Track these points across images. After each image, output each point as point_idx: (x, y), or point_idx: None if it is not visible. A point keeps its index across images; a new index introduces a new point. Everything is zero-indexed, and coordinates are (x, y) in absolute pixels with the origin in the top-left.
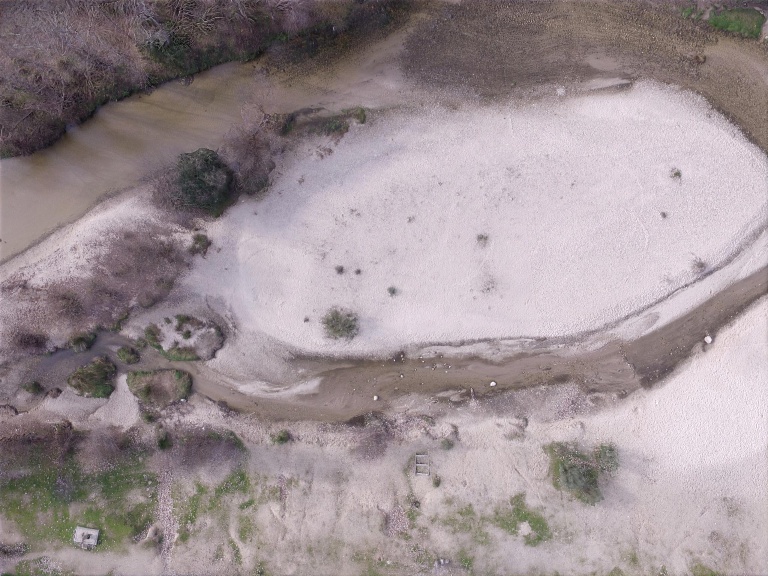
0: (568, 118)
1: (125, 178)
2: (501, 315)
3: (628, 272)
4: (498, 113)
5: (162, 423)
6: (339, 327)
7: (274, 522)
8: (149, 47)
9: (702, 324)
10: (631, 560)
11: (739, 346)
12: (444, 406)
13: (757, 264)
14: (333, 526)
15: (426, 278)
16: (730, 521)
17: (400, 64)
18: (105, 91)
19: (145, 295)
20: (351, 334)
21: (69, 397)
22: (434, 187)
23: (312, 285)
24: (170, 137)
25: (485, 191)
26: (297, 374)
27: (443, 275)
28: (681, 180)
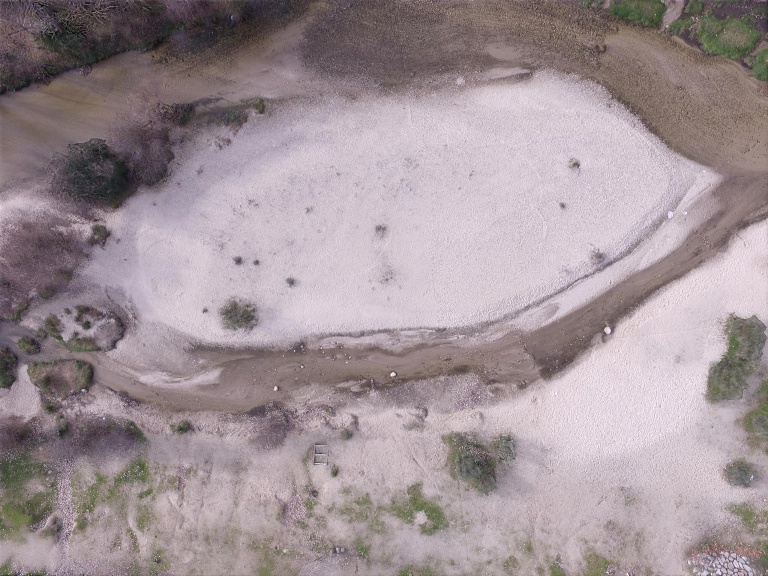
0: (467, 108)
1: (24, 169)
2: (400, 306)
3: (527, 263)
4: (397, 103)
5: (63, 413)
6: (238, 318)
7: (172, 511)
8: (42, 36)
9: (602, 315)
10: (526, 549)
11: (638, 337)
12: (344, 396)
13: (657, 255)
14: (231, 515)
15: (325, 269)
16: (627, 510)
17: (299, 54)
18: (1, 81)
19: (44, 286)
20: (250, 325)
21: None
22: (332, 177)
23: (210, 276)
24: (69, 127)
25: (383, 181)
26: (198, 365)
27: (342, 266)
28: (580, 170)
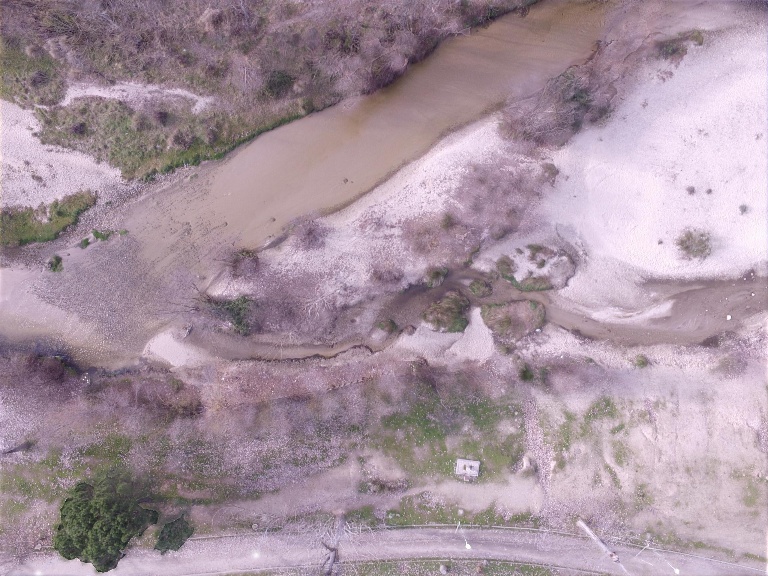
0: None
1: (467, 112)
2: None
3: None
4: None
5: (519, 354)
6: (693, 248)
7: (648, 445)
8: None
9: None
10: None
11: None
12: None
13: None
14: (707, 445)
15: None
16: None
17: None
18: None
19: (498, 226)
20: (704, 254)
21: (425, 333)
22: None
23: (664, 207)
24: (510, 69)
25: None
26: (649, 298)
27: None
28: None
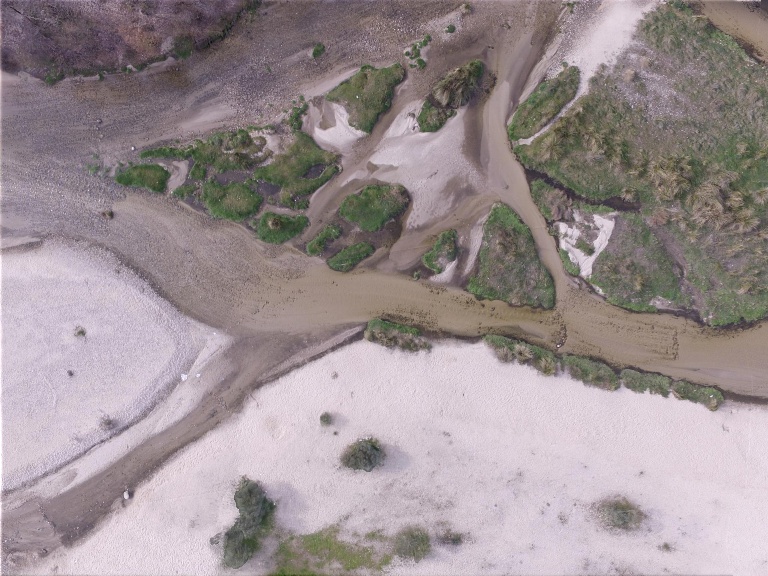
0: None
1: None
2: None
3: (38, 431)
4: None
5: None
6: None
7: None
8: None
9: (121, 479)
10: None
11: (153, 502)
12: None
13: (173, 417)
14: None
15: None
16: None
17: None
18: None
19: None
20: None
21: None
22: None
23: None
24: None
25: None
26: None
27: None
28: (86, 338)
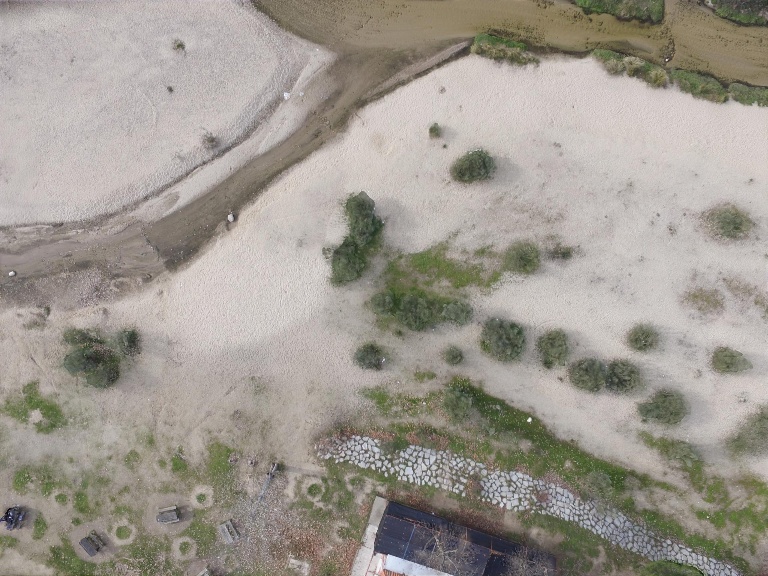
0: None
1: None
2: (10, 201)
3: (138, 150)
4: None
5: None
6: None
7: None
8: None
9: (225, 202)
10: (147, 442)
11: (259, 222)
12: None
13: (276, 138)
14: None
15: None
16: (256, 399)
17: None
18: None
19: None
20: None
21: None
22: None
23: None
24: None
25: None
26: None
27: None
28: (185, 52)
